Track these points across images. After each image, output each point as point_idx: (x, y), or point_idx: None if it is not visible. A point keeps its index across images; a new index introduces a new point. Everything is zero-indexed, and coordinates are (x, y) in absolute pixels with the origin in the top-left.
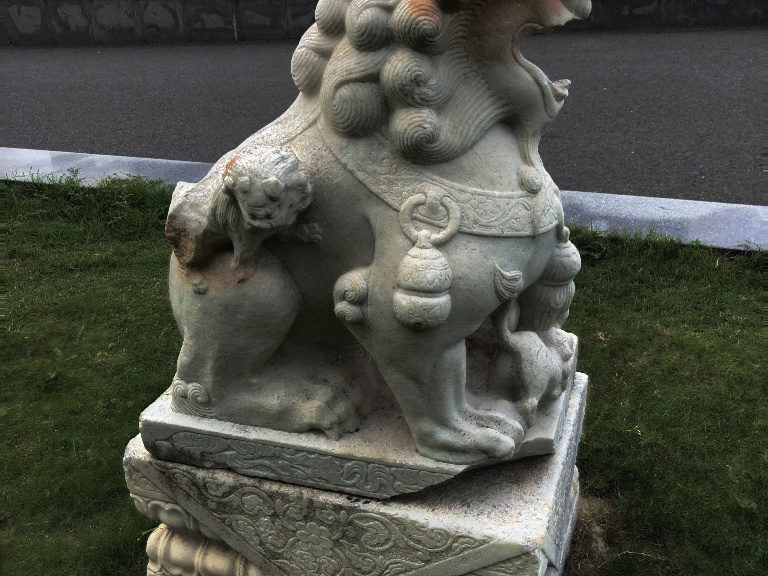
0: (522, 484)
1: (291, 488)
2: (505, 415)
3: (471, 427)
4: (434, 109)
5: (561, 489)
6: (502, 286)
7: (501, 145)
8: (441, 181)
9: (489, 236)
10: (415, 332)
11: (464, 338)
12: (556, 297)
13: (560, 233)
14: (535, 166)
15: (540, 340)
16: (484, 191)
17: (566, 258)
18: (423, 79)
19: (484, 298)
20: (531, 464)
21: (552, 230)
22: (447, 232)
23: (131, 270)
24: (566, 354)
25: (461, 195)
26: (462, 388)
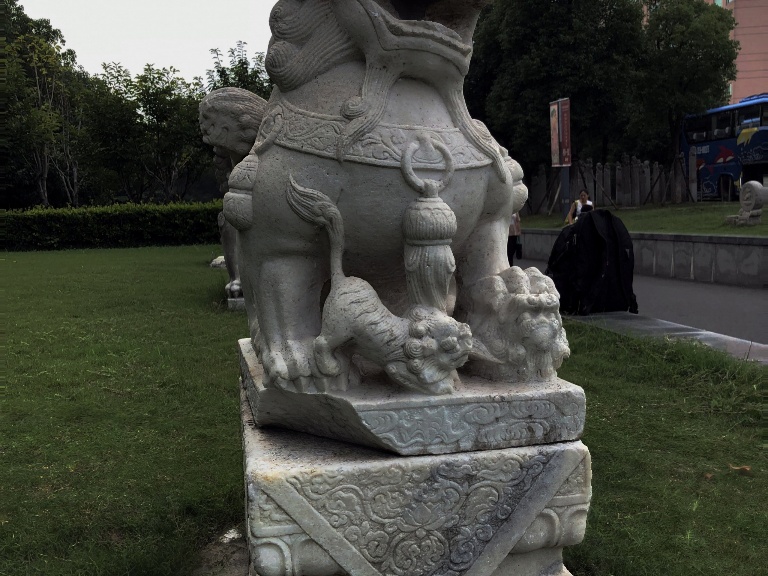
0: (336, 456)
1: (246, 407)
2: (298, 346)
3: (277, 350)
4: (293, 43)
5: (404, 507)
6: (294, 199)
7: (345, 78)
8: (285, 103)
9: (292, 149)
10: (239, 232)
11: (289, 258)
12: (410, 257)
13: (408, 180)
14: (362, 96)
15: (366, 290)
16: (304, 111)
17: (415, 211)
18: (280, 15)
19: (277, 206)
20: (374, 454)
21: (392, 172)
22: (264, 141)
23: (595, 395)
24: (413, 328)
25: (289, 114)
26: (284, 311)
